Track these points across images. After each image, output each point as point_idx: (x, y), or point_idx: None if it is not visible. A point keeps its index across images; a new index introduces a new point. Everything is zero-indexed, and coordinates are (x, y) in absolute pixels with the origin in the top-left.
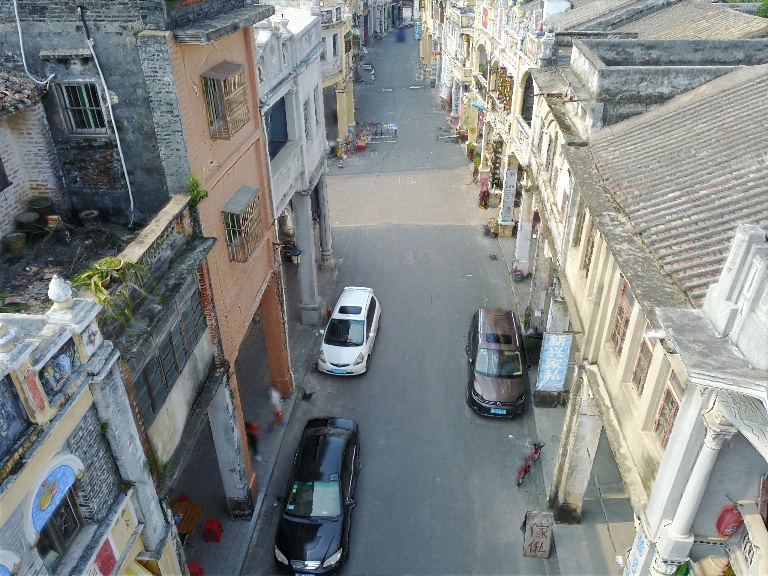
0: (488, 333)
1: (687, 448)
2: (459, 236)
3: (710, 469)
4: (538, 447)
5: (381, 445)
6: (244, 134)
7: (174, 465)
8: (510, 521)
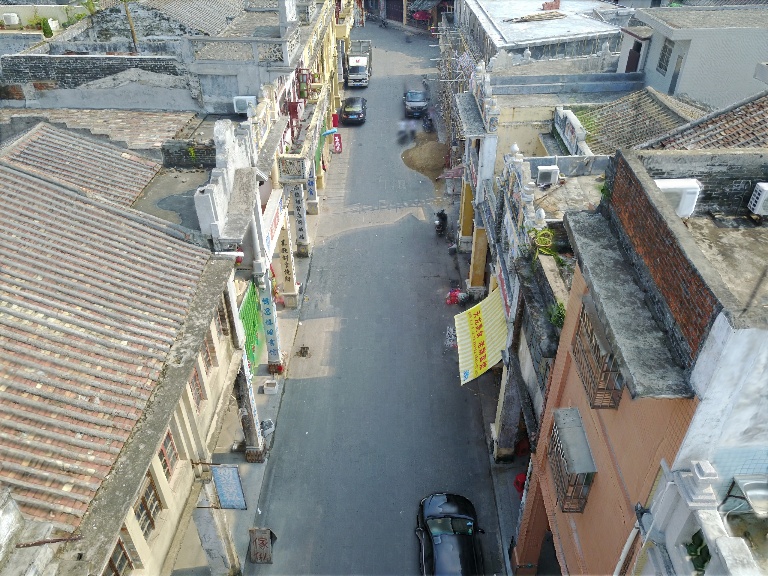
0: None
1: None
2: None
3: None
4: None
5: None
6: (623, 467)
7: (515, 364)
8: (279, 570)
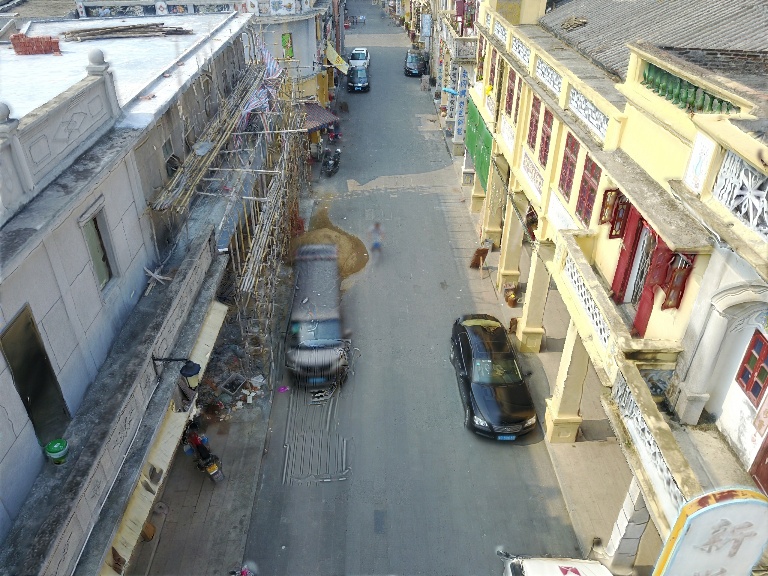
0: (412, 52)
1: (442, 0)
2: (401, 49)
3: None
4: None
5: (375, 80)
6: None
7: None
8: None
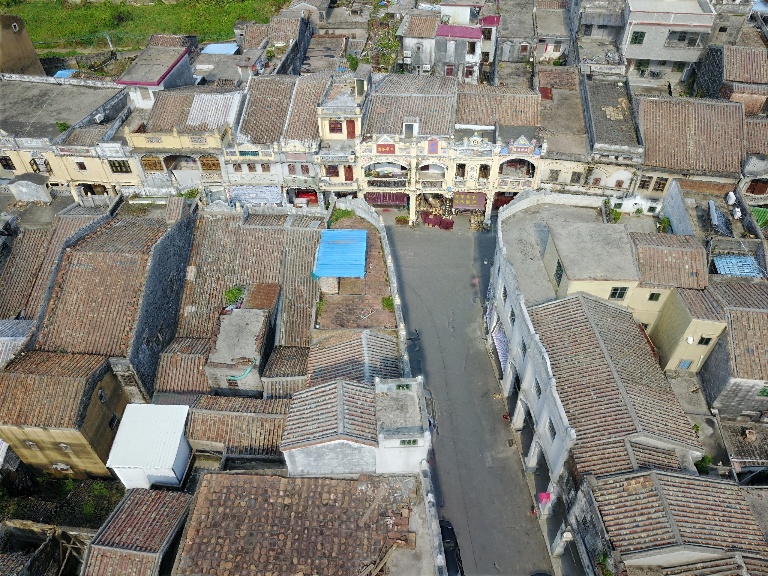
0: None
1: None
2: (488, 242)
3: None
4: None
5: None
6: None
7: None
8: None
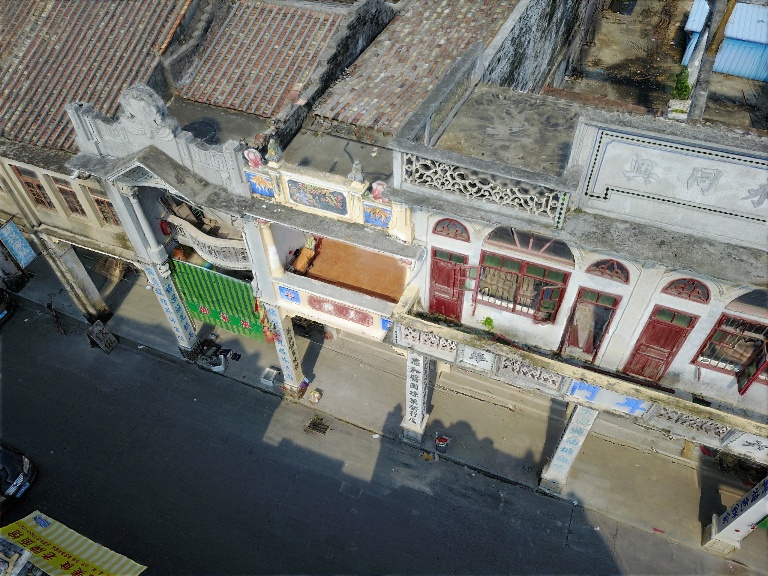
0: None
1: (128, 212)
2: None
3: (143, 212)
4: (50, 306)
5: None
6: None
7: None
8: (83, 351)
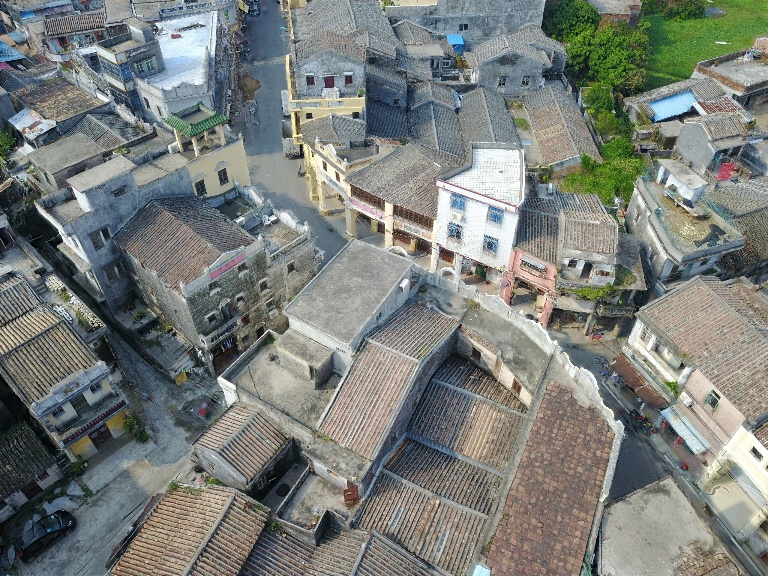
0: None
1: None
2: None
3: None
4: None
5: None
6: None
7: None
8: None
